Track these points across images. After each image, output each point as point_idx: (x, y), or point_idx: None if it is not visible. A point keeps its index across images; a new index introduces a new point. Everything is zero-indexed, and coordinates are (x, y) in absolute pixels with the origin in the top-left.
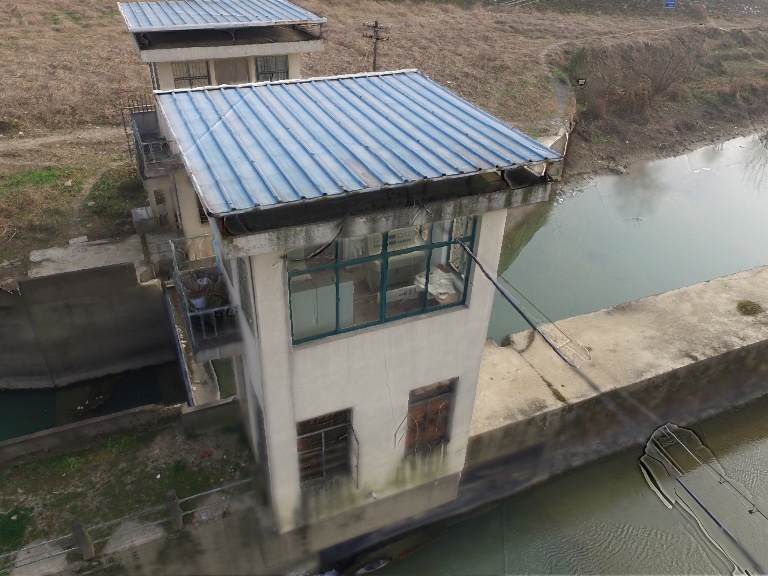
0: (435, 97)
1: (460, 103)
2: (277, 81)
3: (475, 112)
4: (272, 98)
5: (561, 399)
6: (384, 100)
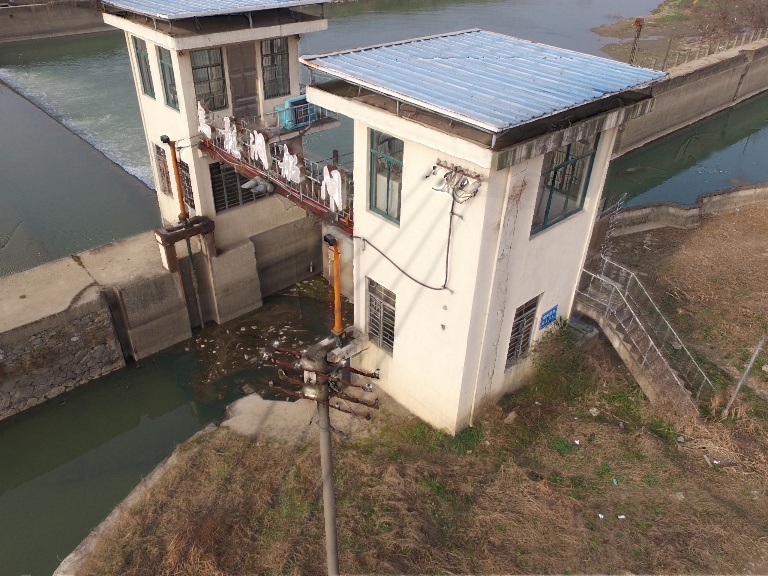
0: (156, 8)
1: (140, 7)
2: (268, 5)
3: (132, 5)
4: (261, 2)
5: (76, 256)
6: (191, 5)
